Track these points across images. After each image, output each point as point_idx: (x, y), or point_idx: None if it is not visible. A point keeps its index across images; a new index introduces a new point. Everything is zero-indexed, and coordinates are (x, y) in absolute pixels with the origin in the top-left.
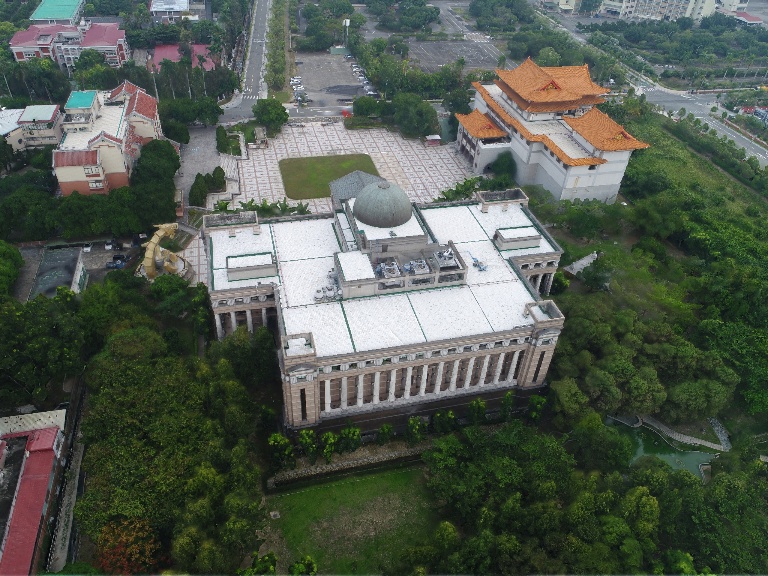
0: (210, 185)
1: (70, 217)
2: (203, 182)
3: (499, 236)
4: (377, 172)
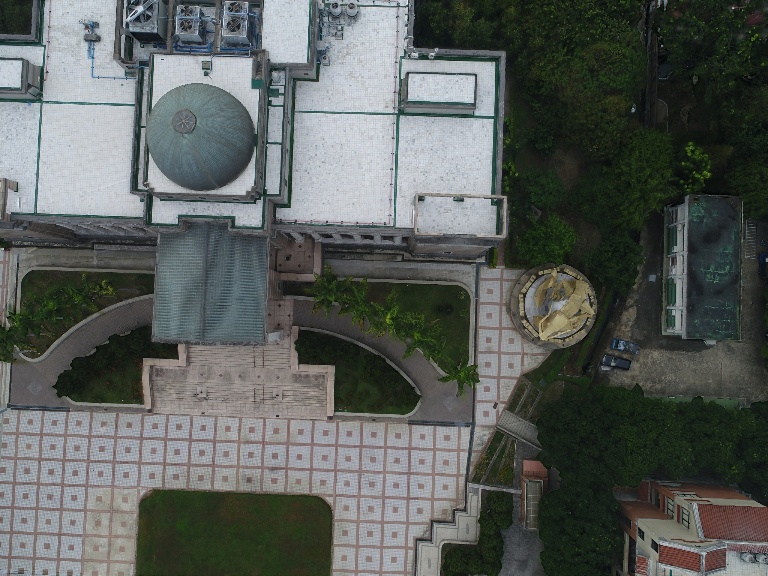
0: (472, 554)
1: (716, 414)
2: (486, 546)
3: (27, 76)
4: (137, 572)
